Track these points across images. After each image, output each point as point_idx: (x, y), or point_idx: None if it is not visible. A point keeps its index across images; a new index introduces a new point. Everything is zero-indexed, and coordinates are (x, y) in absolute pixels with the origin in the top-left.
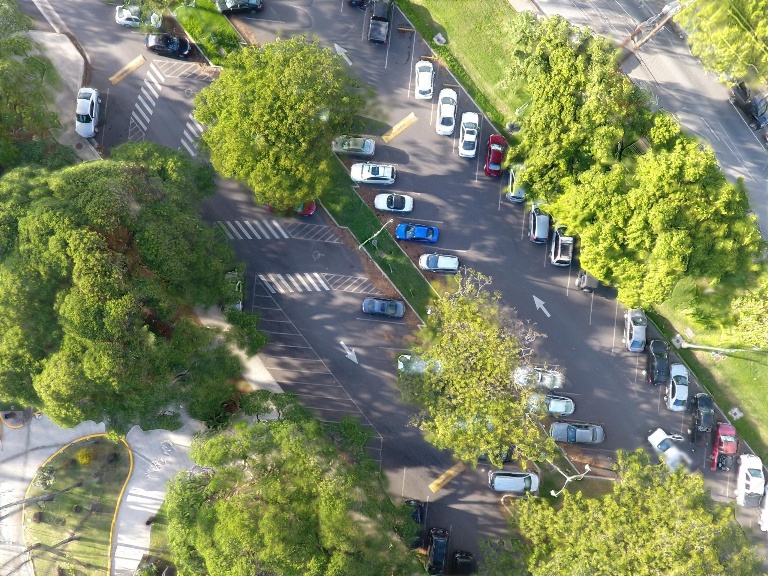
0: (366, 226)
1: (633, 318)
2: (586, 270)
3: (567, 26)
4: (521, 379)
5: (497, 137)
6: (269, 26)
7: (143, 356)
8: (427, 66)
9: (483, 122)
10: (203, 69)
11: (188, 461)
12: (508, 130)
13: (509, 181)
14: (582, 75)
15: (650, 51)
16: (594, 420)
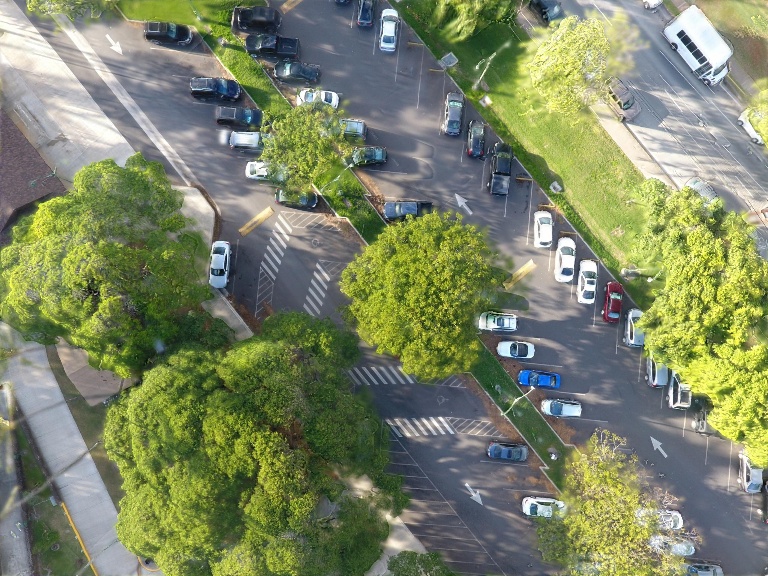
0: (489, 372)
1: (749, 460)
2: (715, 428)
3: (702, 204)
4: (661, 543)
5: (615, 285)
6: (392, 177)
7: (318, 546)
8: (547, 217)
9: (599, 268)
10: (329, 220)
11: None
12: (623, 275)
13: (626, 327)
14: (723, 258)
15: (760, 198)
16: (711, 557)
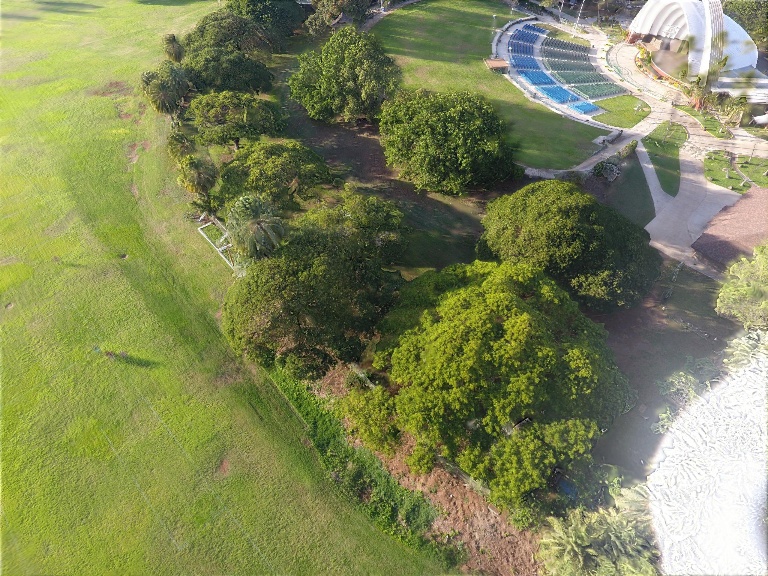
0: None
1: None
2: None
3: None
4: None
5: None
6: None
7: None
8: None
9: None
10: None
11: None
12: None
13: None
14: None
15: None
16: None
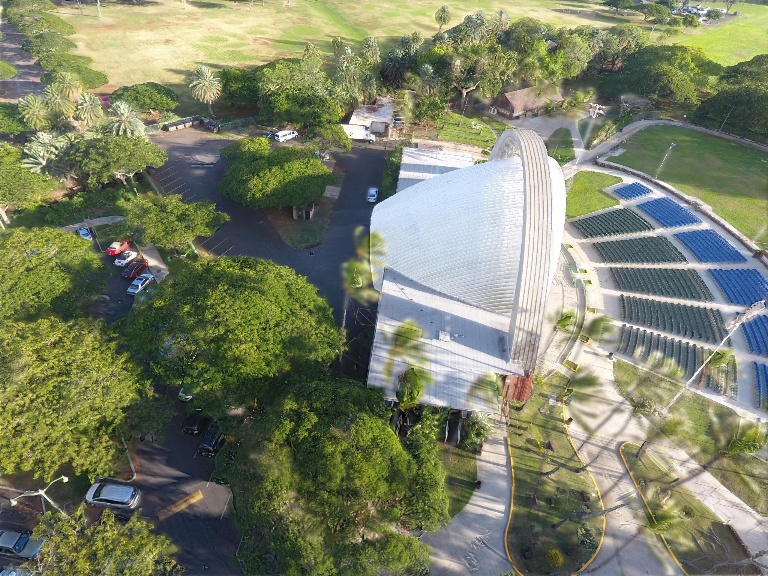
0: None
1: None
2: None
3: None
4: None
5: None
6: None
7: None
8: None
9: None
10: None
11: (448, 544)
12: None
13: None
14: None
15: None
16: None
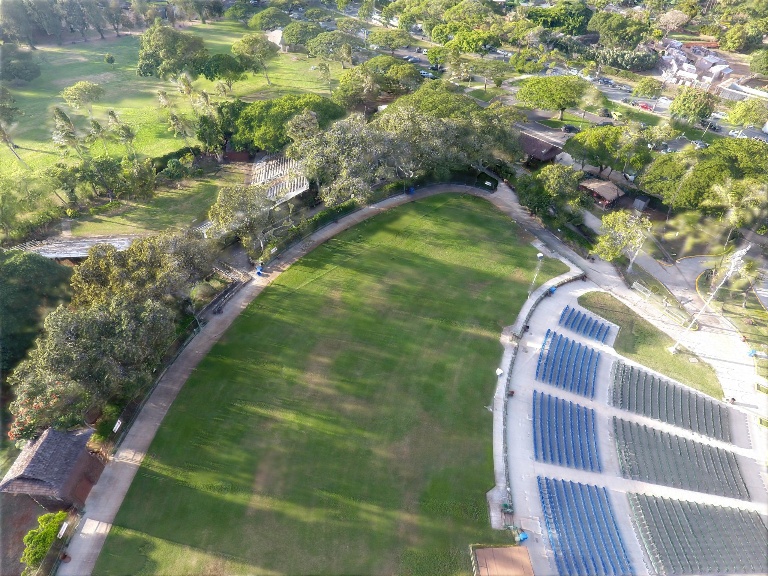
0: None
1: None
2: None
3: None
4: None
5: None
6: None
7: None
8: None
9: None
10: None
11: None
12: None
13: None
14: None
15: None
16: None
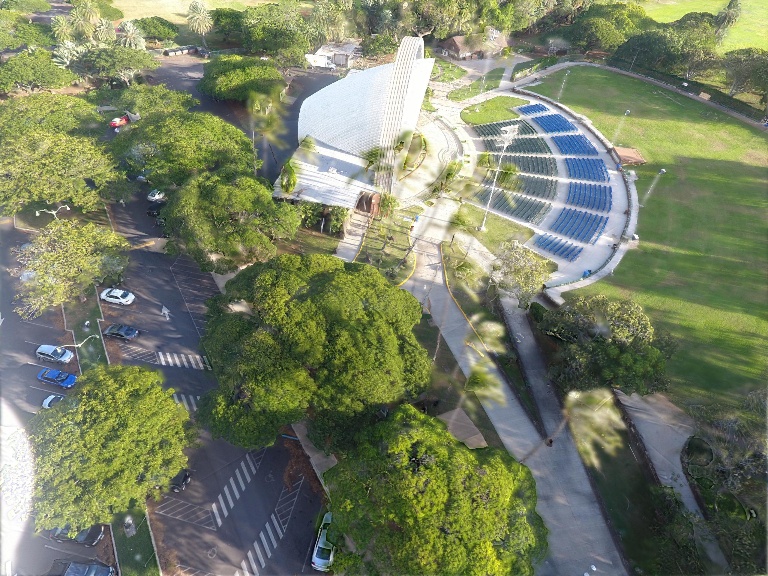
0: None
1: None
2: None
3: None
4: None
5: None
6: None
7: (265, 265)
8: None
9: None
10: None
11: None
12: None
13: None
14: None
15: None
16: None
